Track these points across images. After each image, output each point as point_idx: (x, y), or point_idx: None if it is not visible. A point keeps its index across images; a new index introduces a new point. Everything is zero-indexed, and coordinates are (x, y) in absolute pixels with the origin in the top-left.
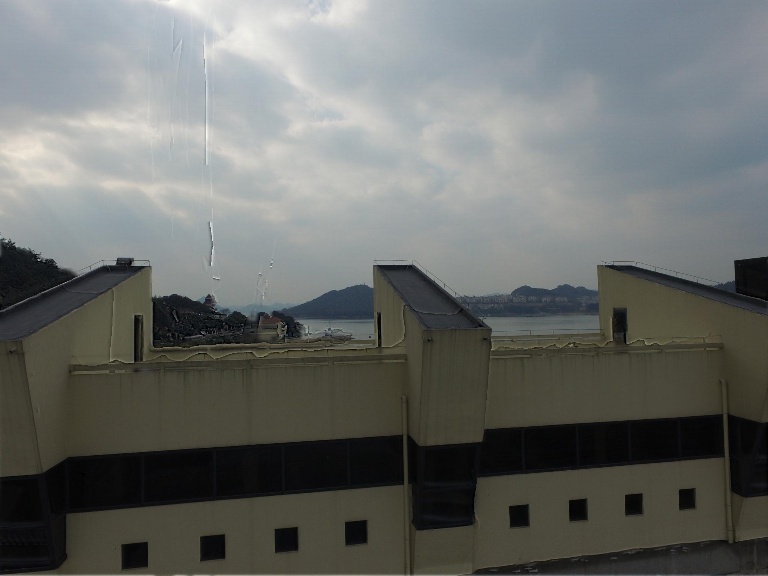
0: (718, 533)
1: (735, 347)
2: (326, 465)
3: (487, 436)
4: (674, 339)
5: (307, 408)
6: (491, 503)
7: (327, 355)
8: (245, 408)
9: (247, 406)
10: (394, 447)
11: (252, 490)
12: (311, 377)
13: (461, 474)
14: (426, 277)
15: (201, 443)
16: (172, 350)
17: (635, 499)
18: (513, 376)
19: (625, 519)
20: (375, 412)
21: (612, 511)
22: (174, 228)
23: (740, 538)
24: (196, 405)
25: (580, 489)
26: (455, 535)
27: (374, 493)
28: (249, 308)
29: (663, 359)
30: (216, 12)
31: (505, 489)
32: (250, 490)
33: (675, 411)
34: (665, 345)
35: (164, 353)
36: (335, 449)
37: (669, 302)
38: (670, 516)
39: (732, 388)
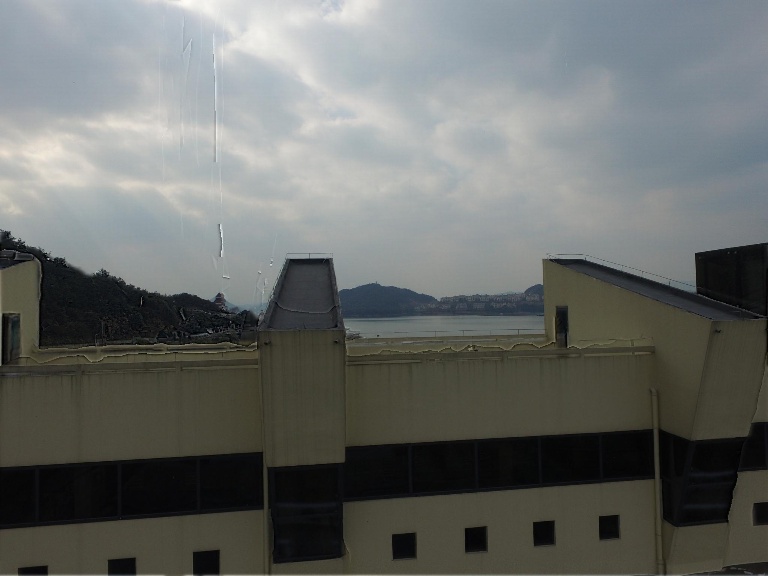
0: (647, 567)
1: (666, 351)
2: (172, 486)
3: (367, 453)
4: (609, 341)
5: (149, 420)
6: (370, 531)
7: (174, 359)
8: (74, 420)
9: (76, 418)
10: (254, 466)
11: (83, 514)
12: (154, 385)
13: (325, 499)
14: (331, 271)
15: (20, 460)
16: (57, 351)
17: (546, 527)
18: (399, 384)
19: (533, 550)
20: (231, 425)
21: (518, 541)
22: (184, 227)
23: (672, 573)
24: (15, 417)
25: (479, 515)
26: (320, 569)
27: (228, 519)
28: (249, 306)
29: (582, 365)
30: (225, 12)
31: (387, 515)
32: (80, 514)
33: (595, 425)
34: (584, 349)
35: (49, 355)
36: (183, 468)
37: (605, 299)
38: (588, 547)
39: (663, 399)
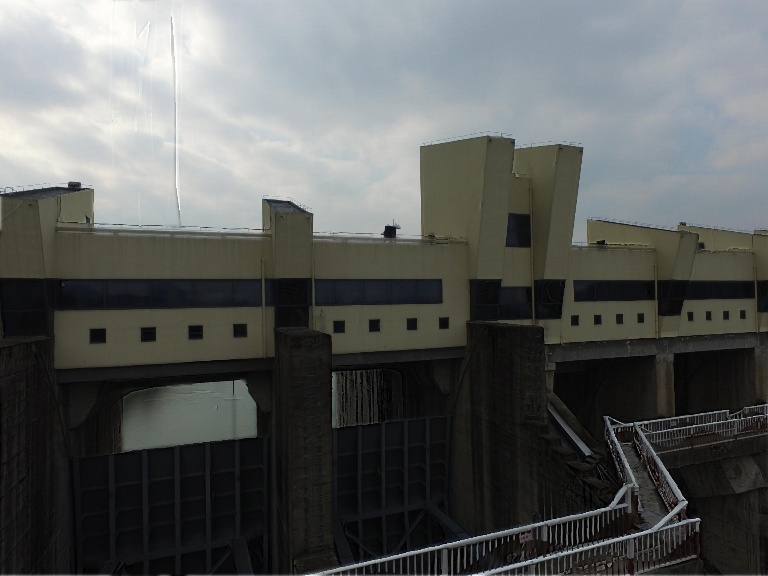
0: None
1: None
2: None
3: None
4: None
5: None
6: None
7: None
8: None
9: None
10: None
11: None
12: None
13: None
14: None
15: None
16: None
17: None
18: None
19: None
20: None
21: None
22: (142, 216)
23: None
24: None
25: None
26: None
27: None
28: None
29: None
30: None
31: None
32: None
33: None
34: None
35: None
36: None
37: None
38: None
39: None
